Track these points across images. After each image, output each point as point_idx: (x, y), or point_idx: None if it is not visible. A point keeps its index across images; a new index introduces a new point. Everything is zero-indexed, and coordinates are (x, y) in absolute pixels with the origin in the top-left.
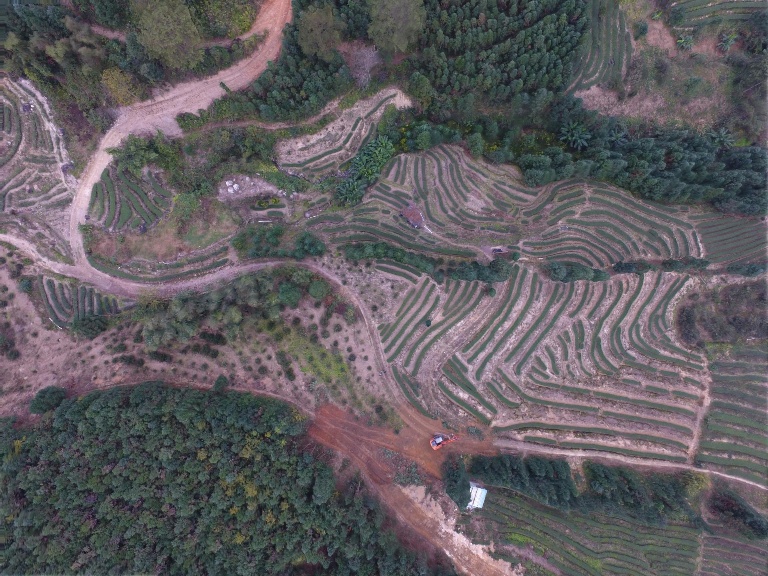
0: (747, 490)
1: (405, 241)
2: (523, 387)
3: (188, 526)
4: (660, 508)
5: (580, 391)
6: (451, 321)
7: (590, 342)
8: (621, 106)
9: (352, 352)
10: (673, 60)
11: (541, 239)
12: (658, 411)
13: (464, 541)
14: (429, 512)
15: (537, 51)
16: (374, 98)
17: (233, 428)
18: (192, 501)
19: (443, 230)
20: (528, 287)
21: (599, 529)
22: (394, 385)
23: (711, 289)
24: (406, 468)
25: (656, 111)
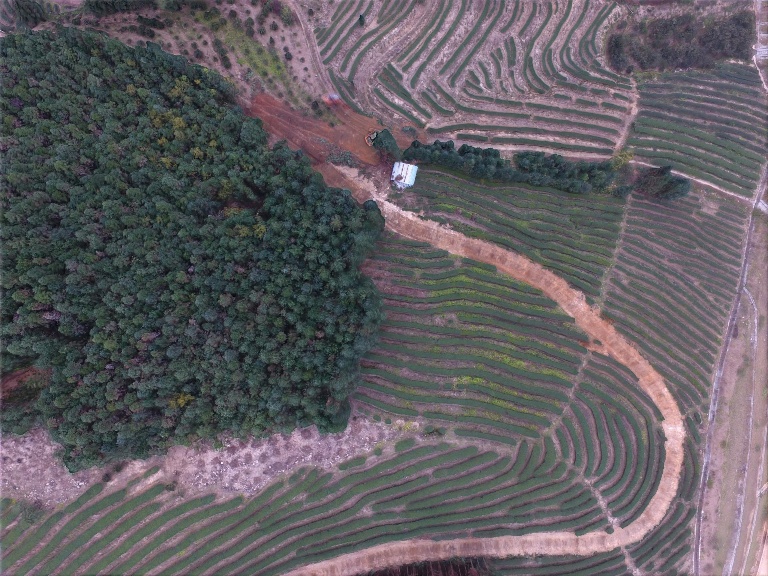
0: None
1: None
2: (457, 99)
3: (114, 141)
4: (584, 178)
5: (513, 104)
6: (385, 29)
7: (522, 62)
8: None
9: None
10: None
11: None
12: (587, 118)
13: (394, 207)
14: (360, 183)
15: None
16: None
17: (162, 68)
18: (119, 123)
19: None
20: None
21: (526, 201)
22: (330, 86)
23: (639, 22)
24: (340, 152)
25: None
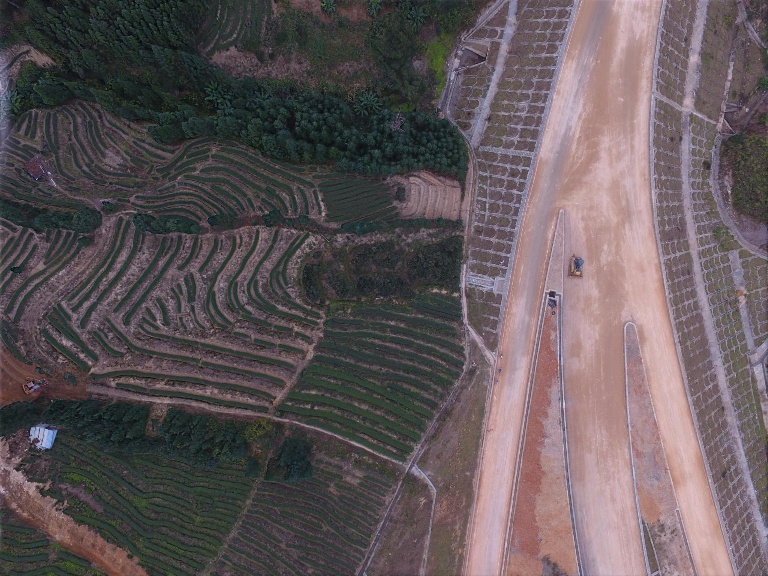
0: (324, 440)
1: (17, 192)
2: (131, 337)
3: None
4: (214, 452)
5: (189, 343)
6: (53, 270)
7: (206, 296)
8: (267, 68)
9: None
10: (315, 23)
11: (157, 194)
12: (258, 363)
13: (20, 478)
14: None
15: (138, 7)
16: (8, 54)
17: None
18: None
19: (70, 184)
20: (132, 239)
21: (158, 471)
22: None
23: (339, 248)
24: None
25: (306, 74)
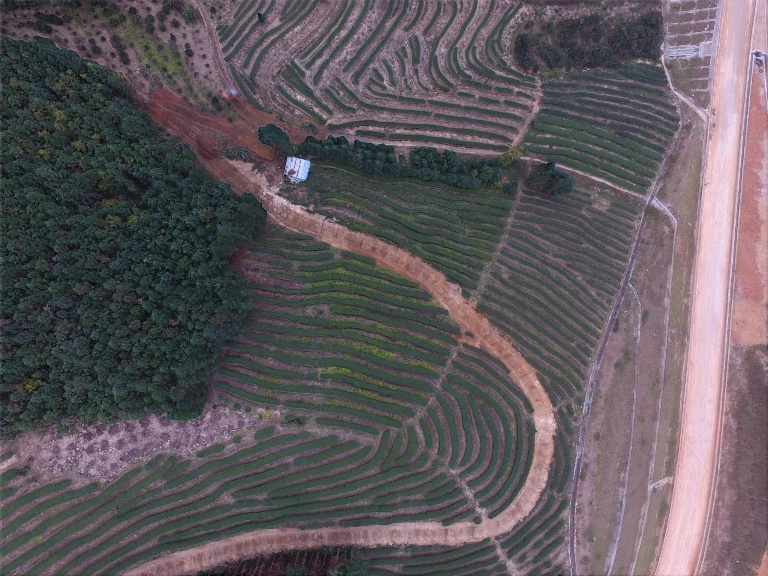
0: None
1: None
2: (361, 96)
3: None
4: (473, 173)
5: (416, 101)
6: (288, 26)
7: (428, 60)
8: None
9: None
10: None
11: None
12: (488, 115)
13: (283, 201)
14: (252, 177)
15: None
16: None
17: (47, 62)
18: None
19: None
20: None
21: (416, 196)
22: (231, 83)
23: (547, 22)
24: (235, 147)
25: None
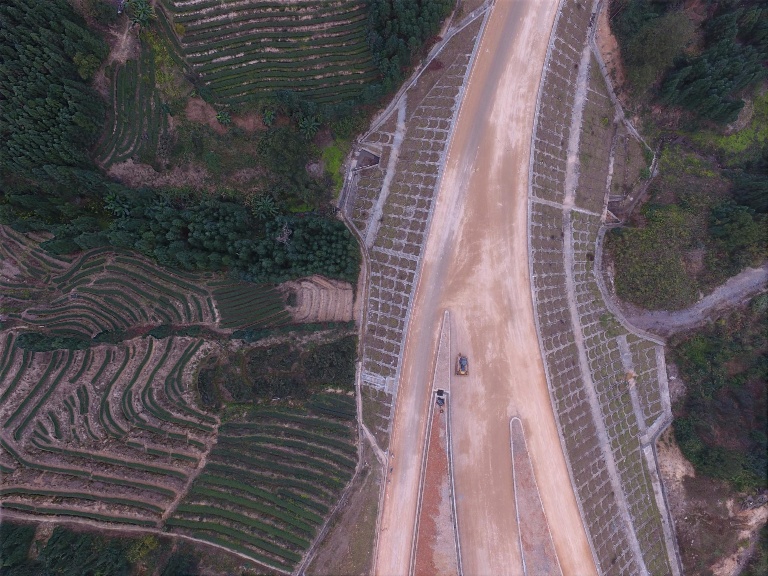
0: (212, 553)
1: None
2: (22, 452)
3: None
4: (96, 575)
5: (81, 455)
6: None
7: (100, 406)
8: (166, 177)
9: None
10: (211, 134)
11: (50, 307)
12: (150, 474)
13: None
14: None
15: None
16: None
17: None
18: None
19: None
20: (22, 355)
21: None
22: None
23: (235, 352)
24: None
25: (205, 181)
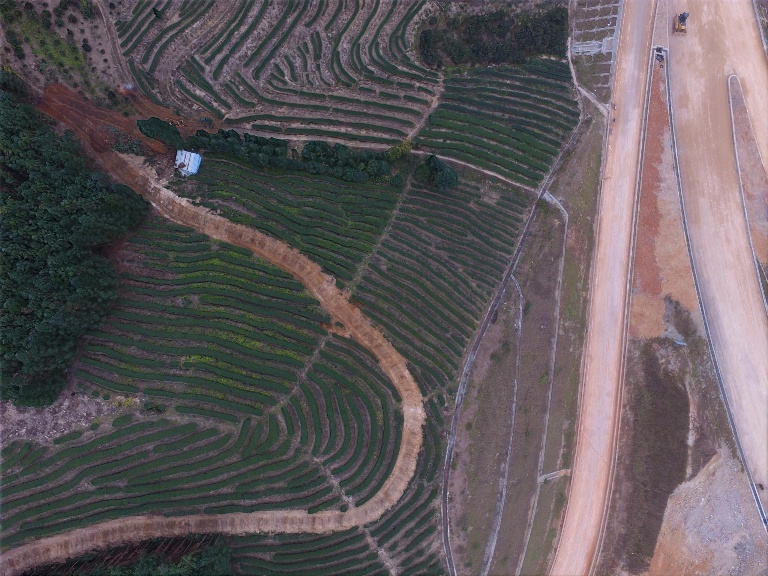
0: (458, 169)
1: None
2: (261, 91)
3: None
4: (360, 166)
5: (316, 96)
6: (187, 22)
7: (330, 56)
8: None
9: (88, 44)
10: None
11: None
12: (386, 110)
13: (170, 194)
14: (140, 170)
15: None
16: None
17: None
18: None
19: None
20: None
21: (304, 188)
22: (130, 77)
23: (452, 18)
24: (128, 140)
25: None
